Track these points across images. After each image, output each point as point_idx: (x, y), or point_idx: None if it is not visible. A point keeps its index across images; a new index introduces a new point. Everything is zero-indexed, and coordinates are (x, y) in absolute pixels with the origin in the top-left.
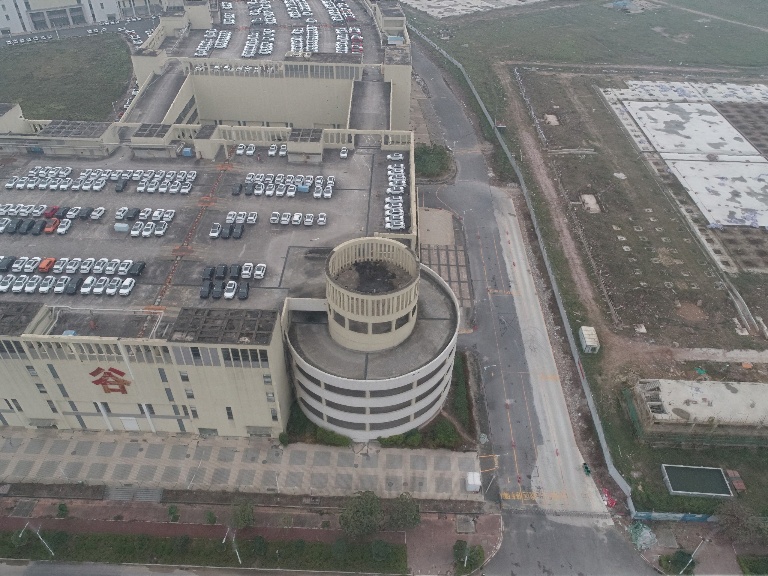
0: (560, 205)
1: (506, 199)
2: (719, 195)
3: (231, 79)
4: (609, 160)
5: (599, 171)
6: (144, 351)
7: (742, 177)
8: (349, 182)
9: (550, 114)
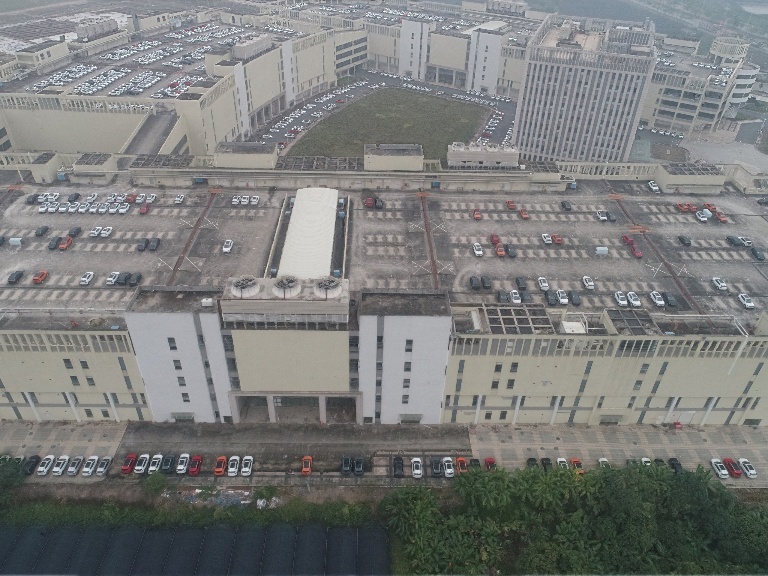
0: None
1: None
2: None
3: None
4: None
5: None
6: None
7: None
8: None
9: None
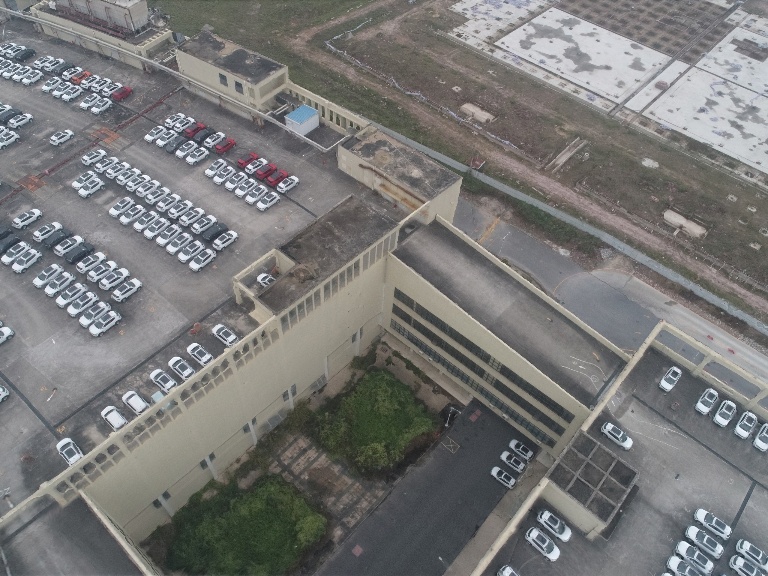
0: (678, 250)
1: (632, 282)
2: (733, 136)
3: (177, 421)
4: (611, 145)
5: (638, 171)
6: None
7: (708, 99)
8: (716, 494)
9: (463, 104)
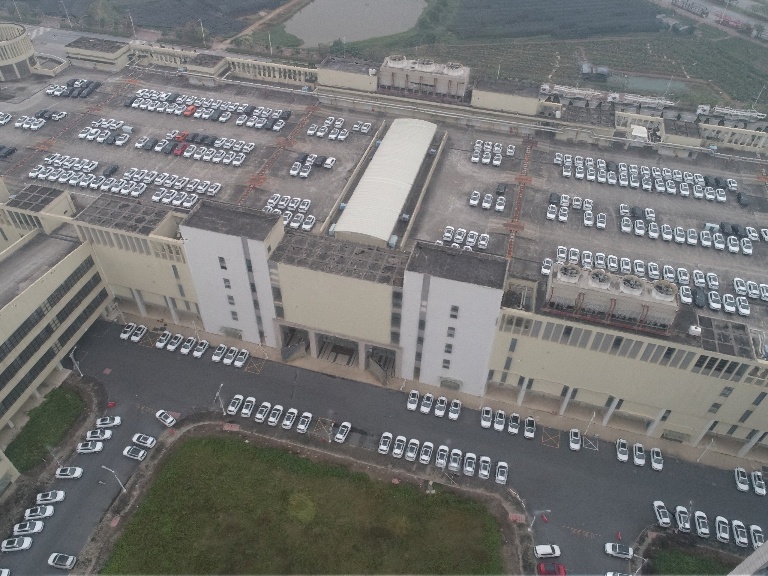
0: None
1: None
2: None
3: None
4: None
5: None
6: (144, 54)
7: None
8: None
9: None
